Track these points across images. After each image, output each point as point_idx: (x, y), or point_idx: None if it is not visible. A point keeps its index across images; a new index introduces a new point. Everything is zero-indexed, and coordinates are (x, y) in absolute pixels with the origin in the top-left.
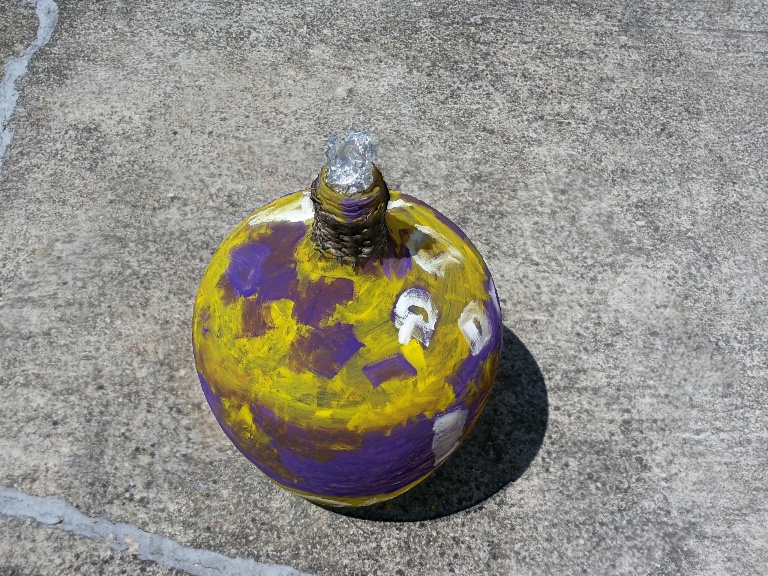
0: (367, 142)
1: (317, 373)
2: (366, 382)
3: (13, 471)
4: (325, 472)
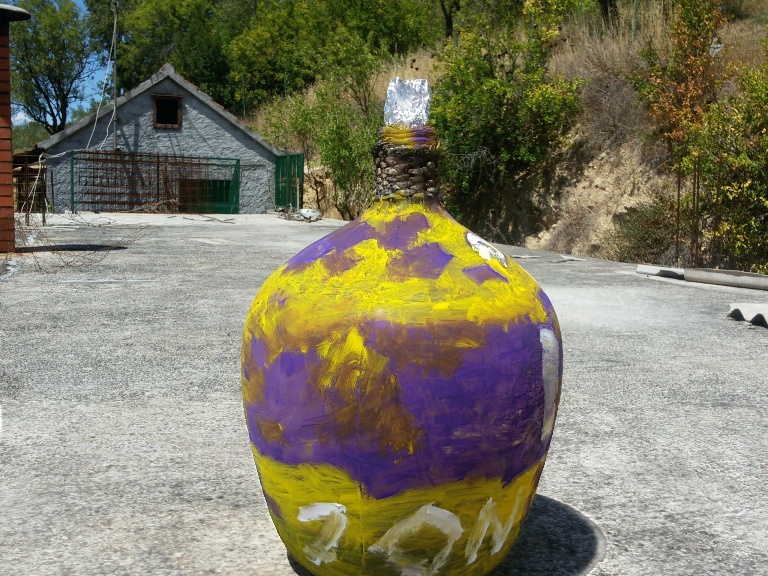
0: None
1: (421, 277)
2: (469, 281)
3: None
4: (450, 398)
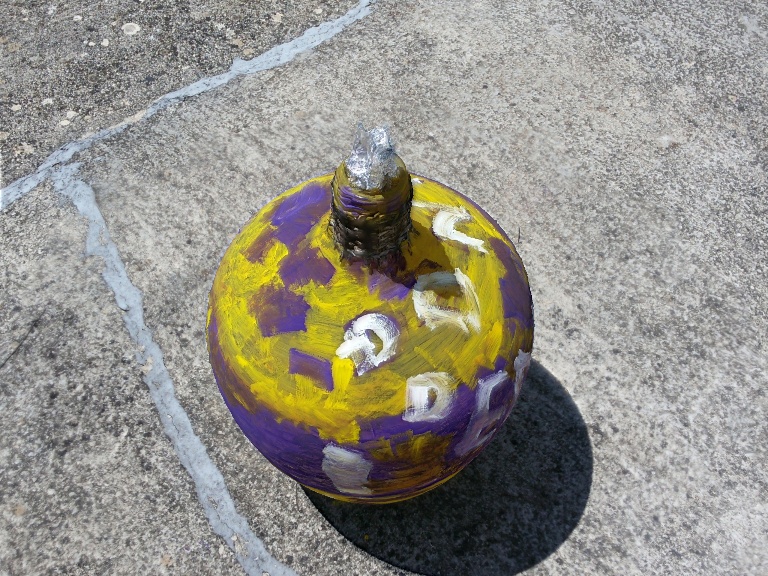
0: (378, 143)
1: (259, 324)
2: (286, 362)
3: (135, 253)
4: (233, 413)
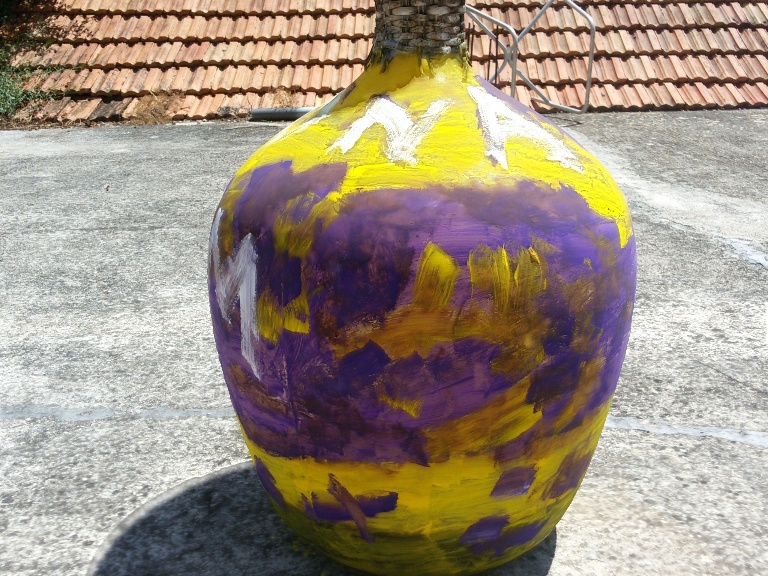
0: None
1: None
2: None
3: None
4: None
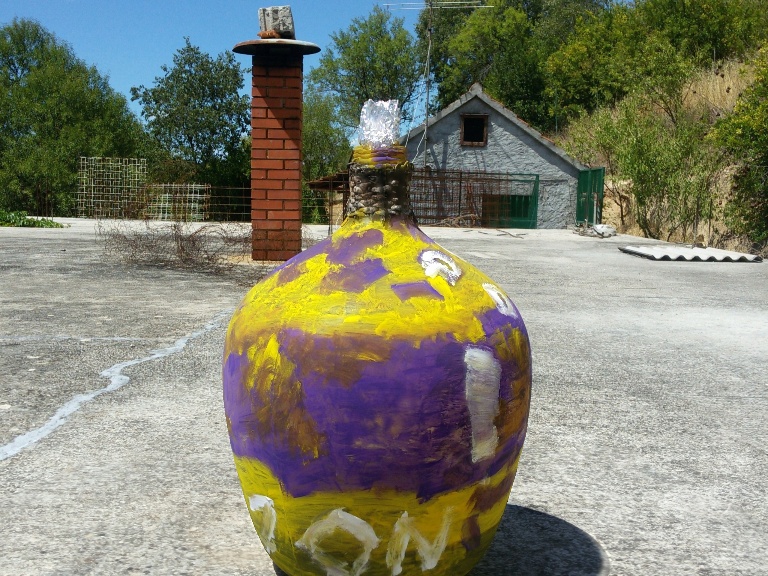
0: None
1: (347, 291)
2: (395, 297)
3: None
4: (350, 408)
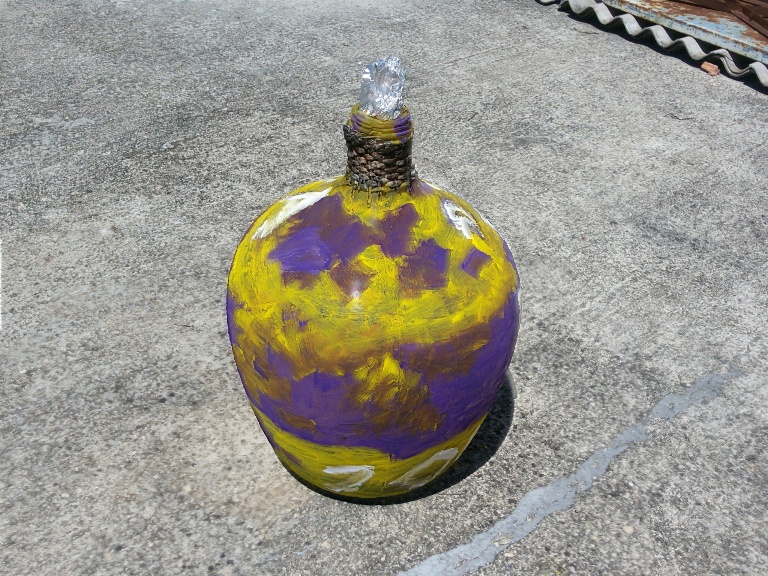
0: None
1: (435, 288)
2: (470, 277)
3: None
4: (468, 387)
